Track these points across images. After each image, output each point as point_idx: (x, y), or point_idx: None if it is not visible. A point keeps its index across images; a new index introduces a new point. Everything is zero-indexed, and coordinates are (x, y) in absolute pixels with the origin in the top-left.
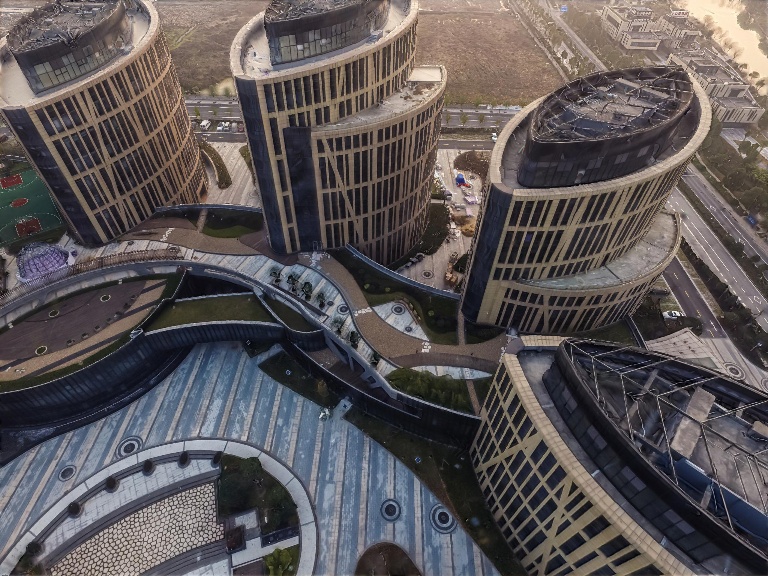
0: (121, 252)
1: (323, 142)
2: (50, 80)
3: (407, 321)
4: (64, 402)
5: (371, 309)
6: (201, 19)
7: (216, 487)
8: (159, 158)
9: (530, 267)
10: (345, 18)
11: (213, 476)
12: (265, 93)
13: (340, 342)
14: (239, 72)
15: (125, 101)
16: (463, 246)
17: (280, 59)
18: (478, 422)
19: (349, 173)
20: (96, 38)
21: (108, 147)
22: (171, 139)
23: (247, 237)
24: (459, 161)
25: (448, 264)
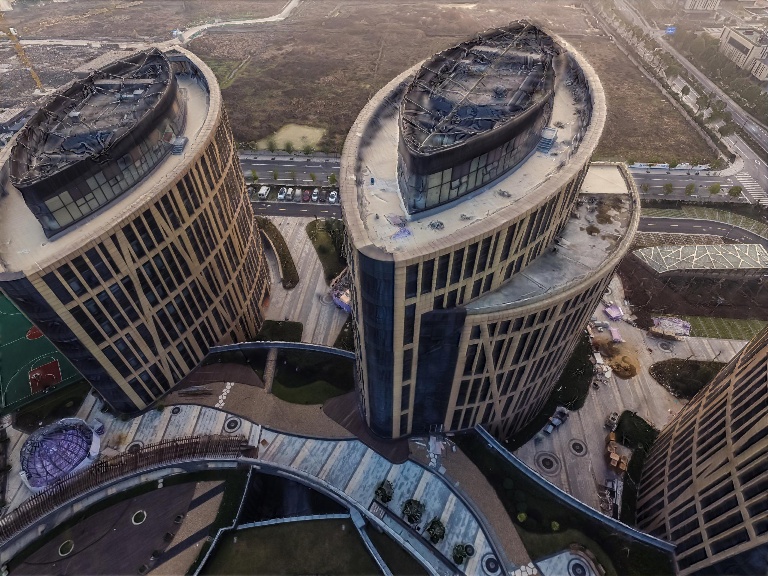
0: (163, 440)
1: (481, 327)
2: (69, 215)
3: None
4: None
5: (535, 568)
6: (255, 49)
7: None
8: (216, 285)
9: None
10: (522, 128)
11: None
12: (406, 276)
13: None
14: (363, 239)
15: (174, 229)
16: (619, 396)
17: (422, 204)
18: None
19: (507, 356)
20: (137, 141)
21: (149, 295)
22: (231, 254)
23: (333, 404)
24: None
25: (606, 432)
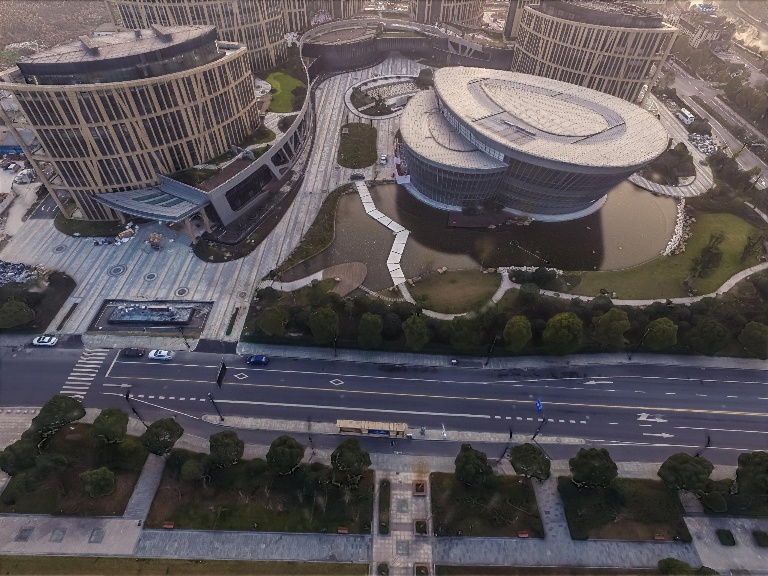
0: None
1: None
2: None
3: (482, 36)
4: (350, 58)
5: (466, 34)
6: None
7: (414, 82)
8: None
9: (533, 0)
10: None
11: (411, 81)
12: None
13: (456, 39)
14: None
15: None
16: None
17: None
18: (513, 53)
19: None
20: None
21: None
22: None
23: None
24: (493, 15)
25: None
